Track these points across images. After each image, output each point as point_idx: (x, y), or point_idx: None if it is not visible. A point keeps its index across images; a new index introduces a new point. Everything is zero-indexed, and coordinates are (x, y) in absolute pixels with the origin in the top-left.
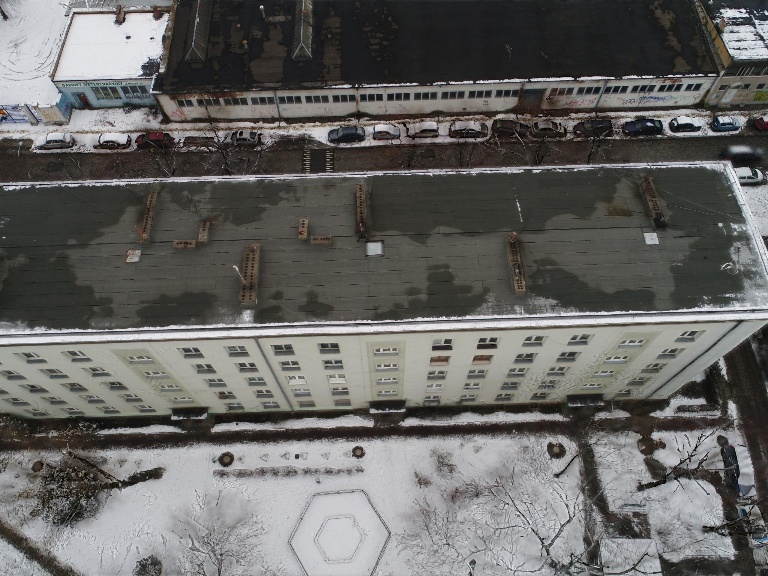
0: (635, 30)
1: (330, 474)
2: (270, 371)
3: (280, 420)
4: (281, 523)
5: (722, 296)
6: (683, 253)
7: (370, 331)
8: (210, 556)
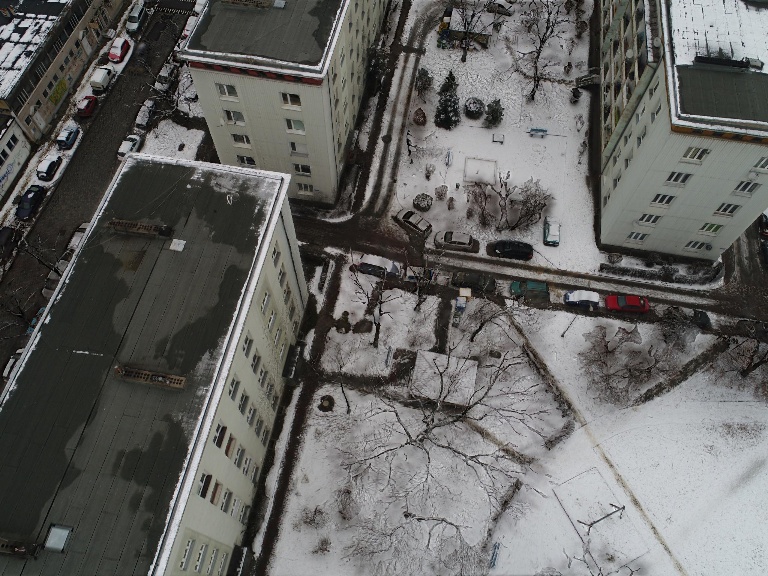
0: None
1: None
2: None
3: None
4: None
5: (255, 215)
6: (203, 226)
7: (164, 569)
8: None
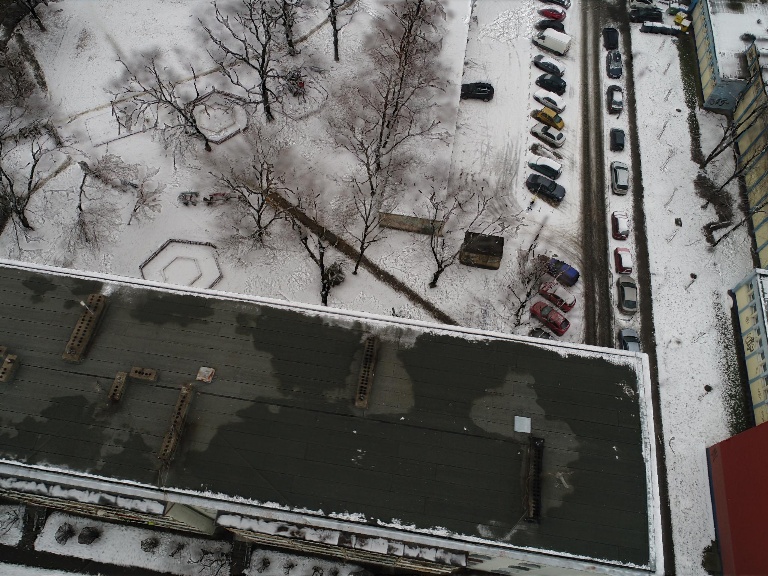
0: None
1: None
2: None
3: None
4: None
5: None
6: None
7: None
8: None
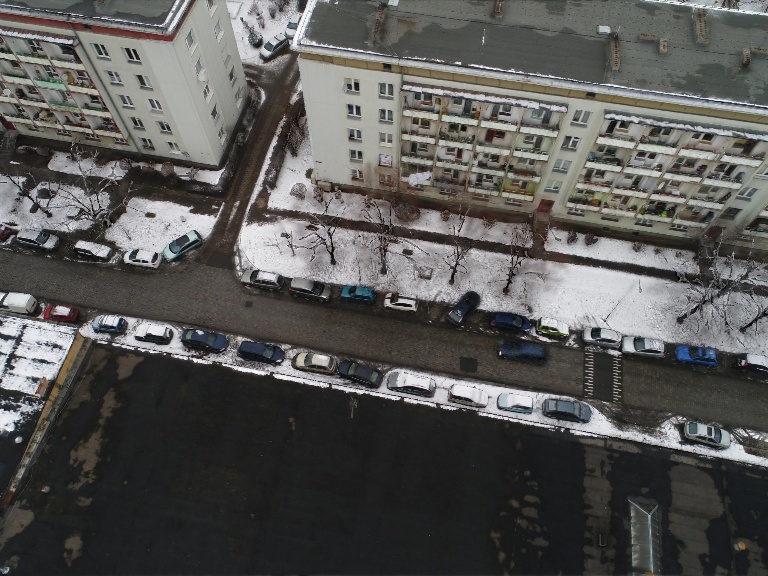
0: (145, 439)
1: None
2: None
3: None
4: None
5: None
6: None
7: None
8: None
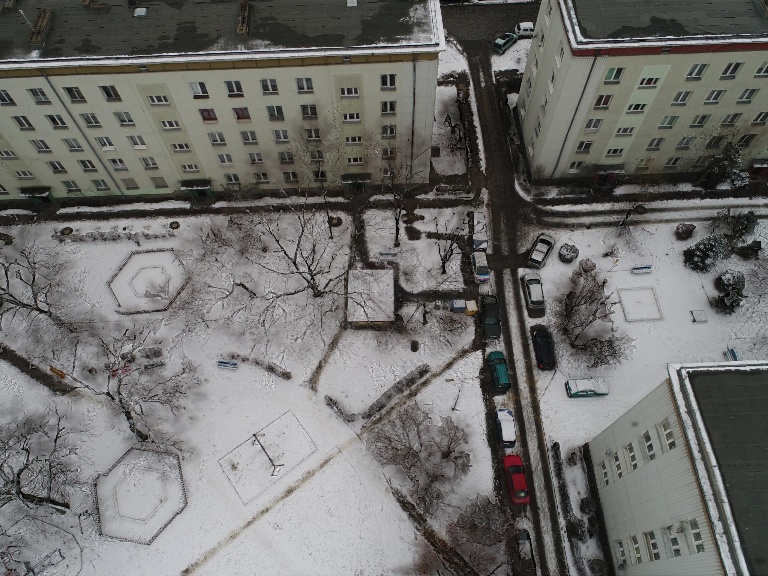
0: None
1: (147, 237)
2: (78, 128)
3: (114, 205)
4: (104, 272)
5: (395, 37)
6: (374, 12)
7: (127, 63)
8: (28, 269)
